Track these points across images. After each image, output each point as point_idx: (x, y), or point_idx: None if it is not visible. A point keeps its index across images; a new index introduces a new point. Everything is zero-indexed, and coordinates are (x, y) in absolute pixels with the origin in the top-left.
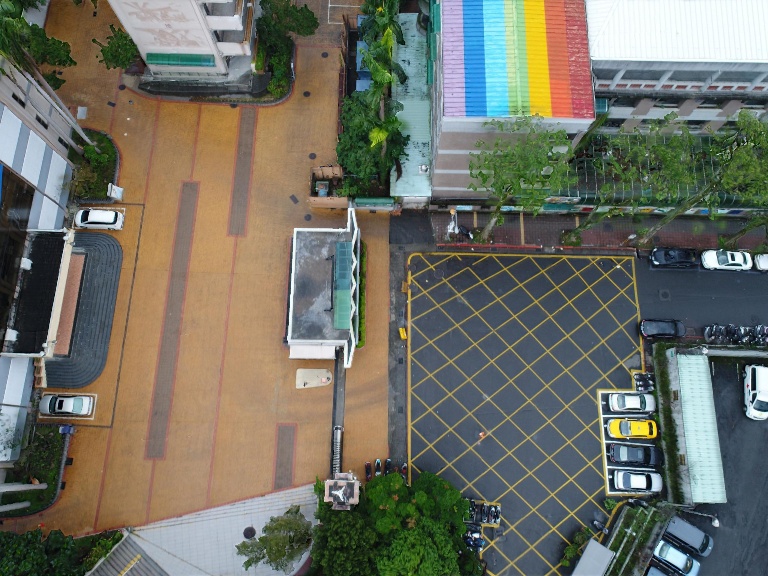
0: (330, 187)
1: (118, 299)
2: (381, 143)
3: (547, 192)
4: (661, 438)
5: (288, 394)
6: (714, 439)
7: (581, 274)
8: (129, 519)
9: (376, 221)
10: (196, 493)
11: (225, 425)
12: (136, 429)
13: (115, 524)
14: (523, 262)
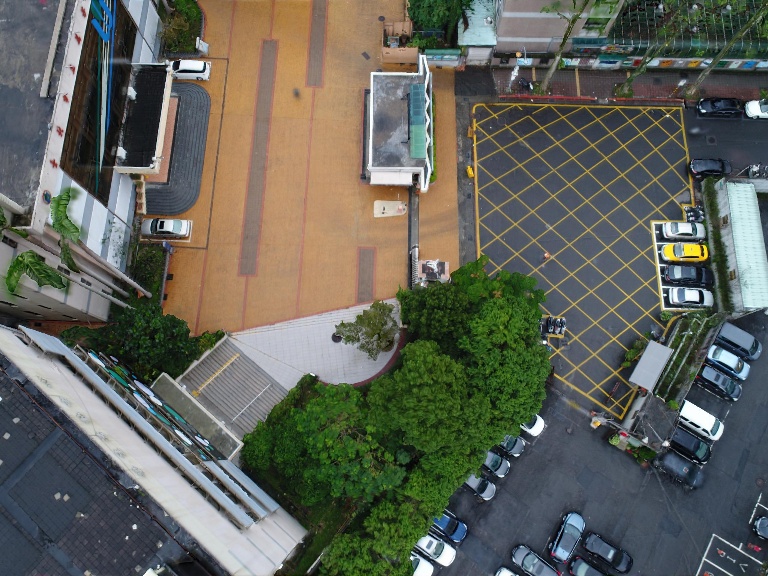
0: (399, 45)
1: (208, 140)
2: None
3: (603, 41)
4: (711, 262)
5: (367, 222)
6: (762, 255)
7: (633, 122)
8: (226, 326)
9: (442, 75)
10: (286, 305)
11: (310, 248)
12: (229, 250)
13: (214, 330)
14: (579, 111)
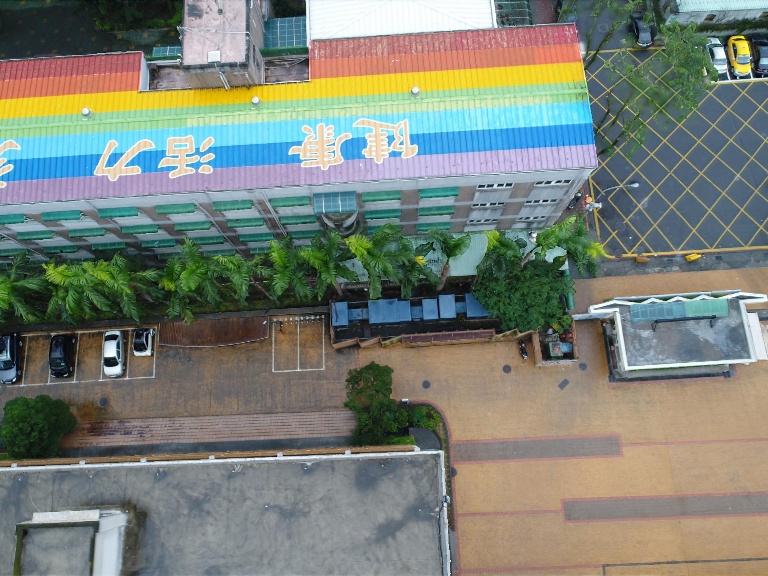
0: (543, 345)
1: None
2: (561, 261)
3: None
4: None
5: None
6: None
7: (596, 97)
8: None
9: None
10: None
11: None
12: None
13: None
14: None
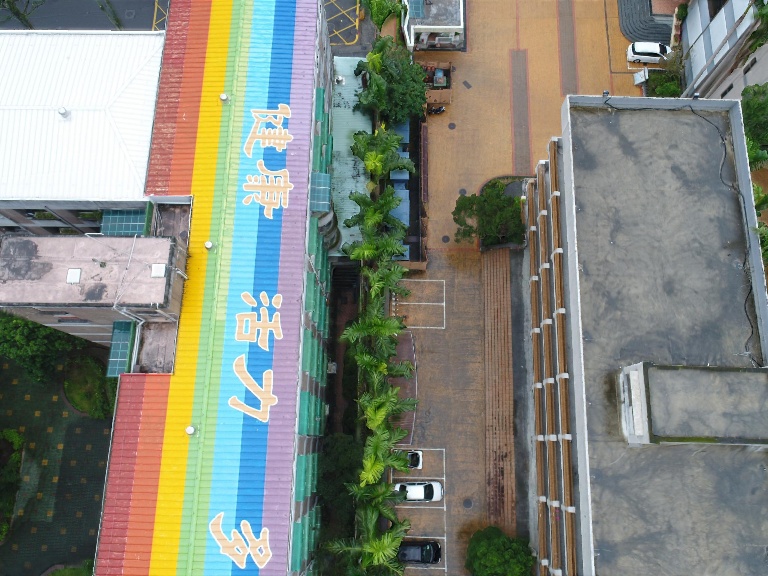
0: None
1: None
2: None
3: None
4: None
5: None
6: None
7: None
8: None
9: None
10: None
11: None
12: None
13: None
14: None
